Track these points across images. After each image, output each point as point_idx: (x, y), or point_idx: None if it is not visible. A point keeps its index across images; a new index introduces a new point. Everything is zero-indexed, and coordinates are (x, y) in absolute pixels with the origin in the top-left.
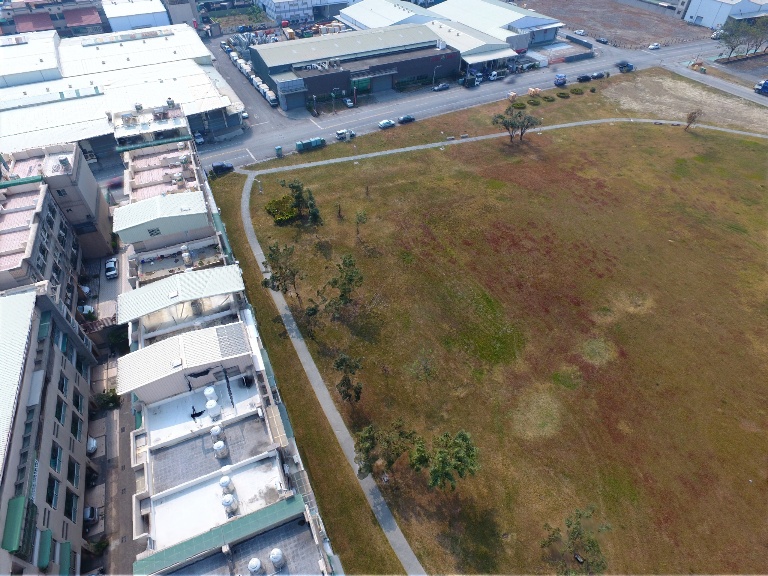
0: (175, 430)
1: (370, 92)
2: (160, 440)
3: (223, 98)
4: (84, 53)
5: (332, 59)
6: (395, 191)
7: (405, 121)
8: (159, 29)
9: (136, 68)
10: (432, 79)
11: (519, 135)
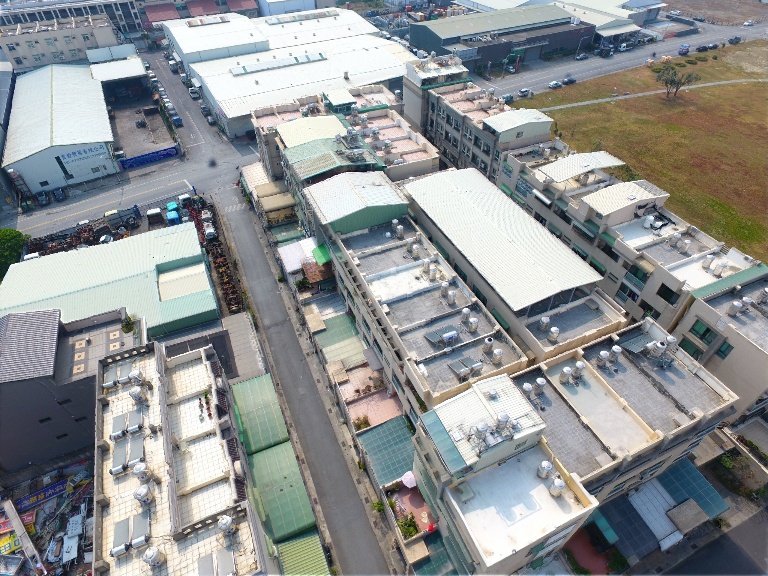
0: (636, 241)
1: (523, 61)
2: (631, 246)
3: None
4: (274, 30)
5: (492, 32)
6: (593, 133)
7: (569, 82)
8: None
9: (325, 42)
10: (571, 50)
11: (673, 92)
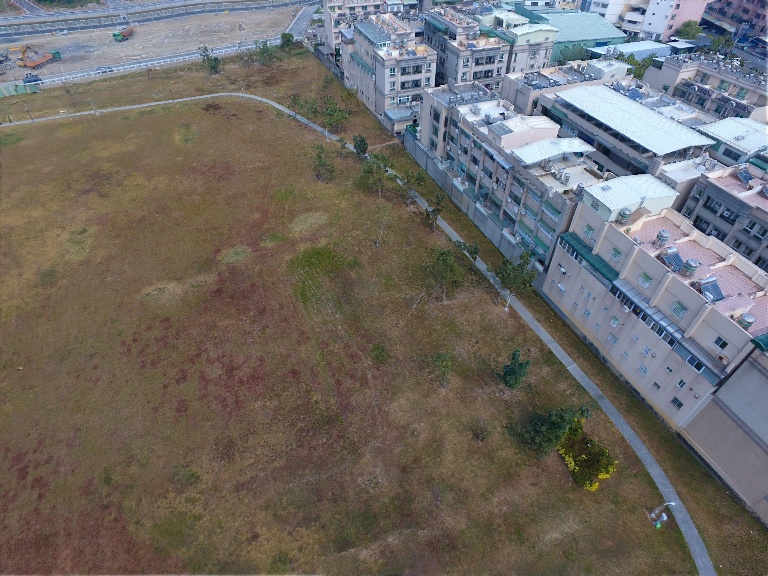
0: None
1: None
2: None
3: None
4: None
5: None
6: (384, 511)
7: None
8: None
9: None
10: None
11: None
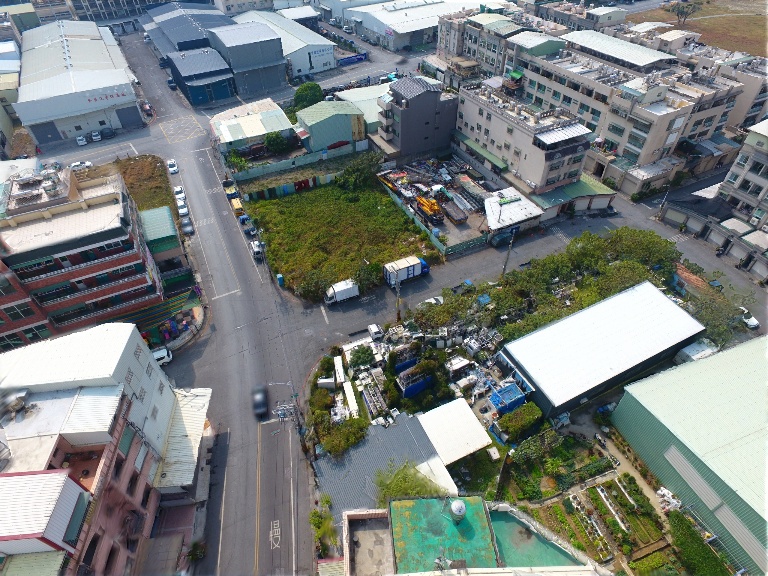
0: None
1: None
2: None
3: (511, 3)
4: None
5: None
6: None
7: None
8: None
9: None
10: (603, 0)
11: (682, 21)
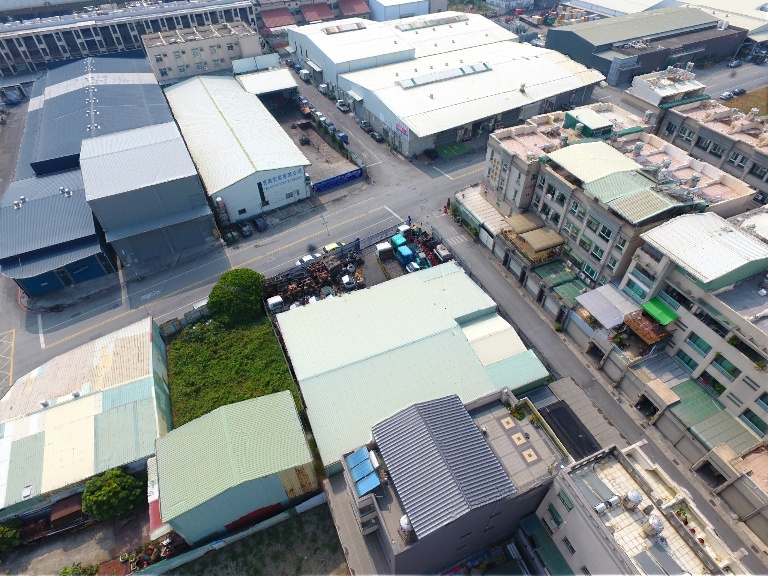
0: None
1: None
2: None
3: (595, 72)
4: (409, 37)
5: (645, 38)
6: None
7: (740, 93)
8: (454, 15)
9: (468, 49)
10: (721, 57)
11: None
